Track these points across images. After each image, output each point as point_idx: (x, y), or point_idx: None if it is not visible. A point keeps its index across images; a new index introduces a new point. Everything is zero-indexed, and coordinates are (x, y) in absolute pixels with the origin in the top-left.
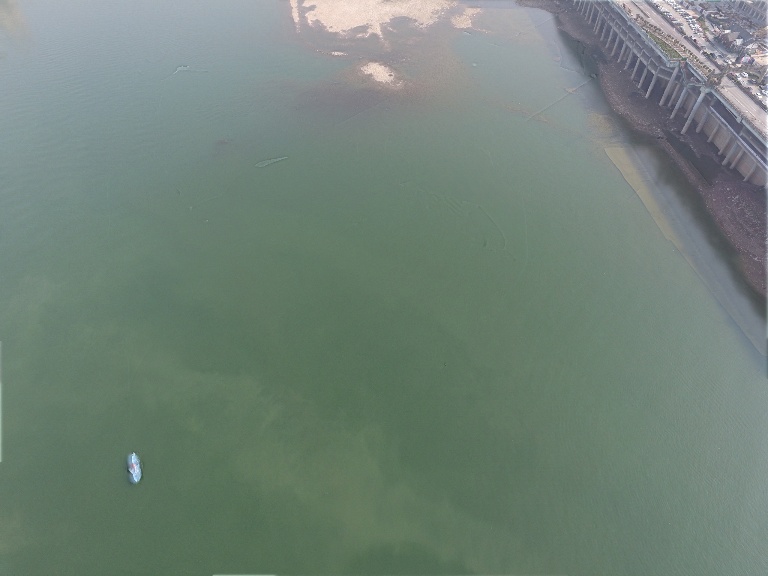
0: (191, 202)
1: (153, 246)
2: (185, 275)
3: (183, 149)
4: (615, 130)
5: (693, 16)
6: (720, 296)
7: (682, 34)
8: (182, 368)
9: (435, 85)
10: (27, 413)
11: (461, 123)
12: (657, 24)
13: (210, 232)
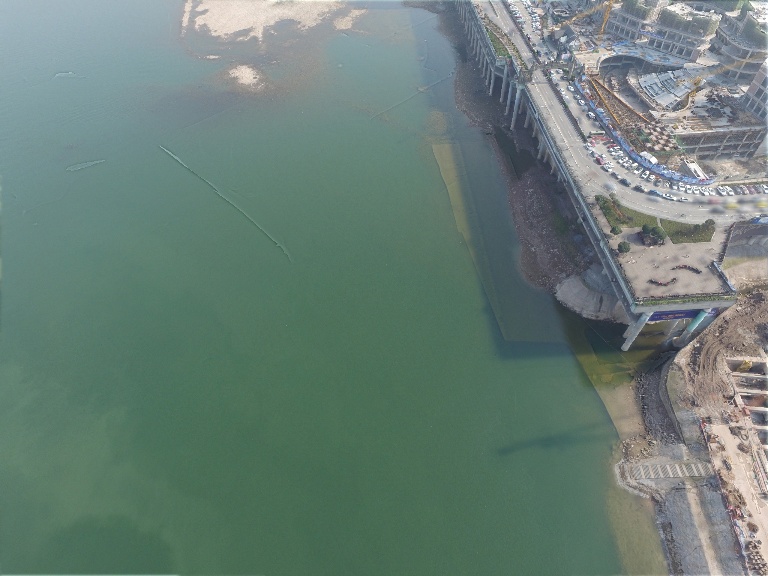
0: (26, 206)
1: None
2: None
3: (27, 154)
4: (449, 127)
5: (539, 14)
6: (487, 285)
7: (520, 32)
8: None
9: (294, 86)
10: None
11: (306, 123)
12: (502, 23)
13: (33, 235)
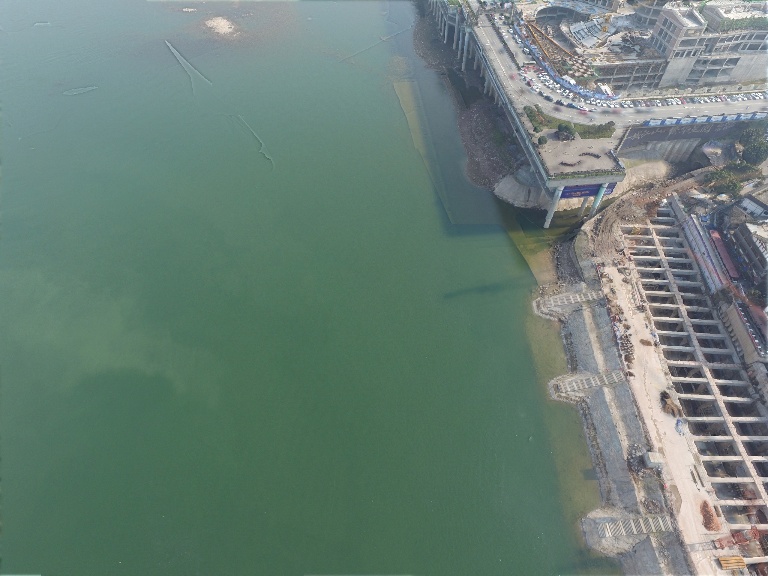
0: (21, 134)
1: None
2: None
3: (18, 89)
4: (409, 69)
5: None
6: (438, 186)
7: None
8: None
9: (267, 35)
10: None
11: (280, 66)
12: None
13: (32, 156)
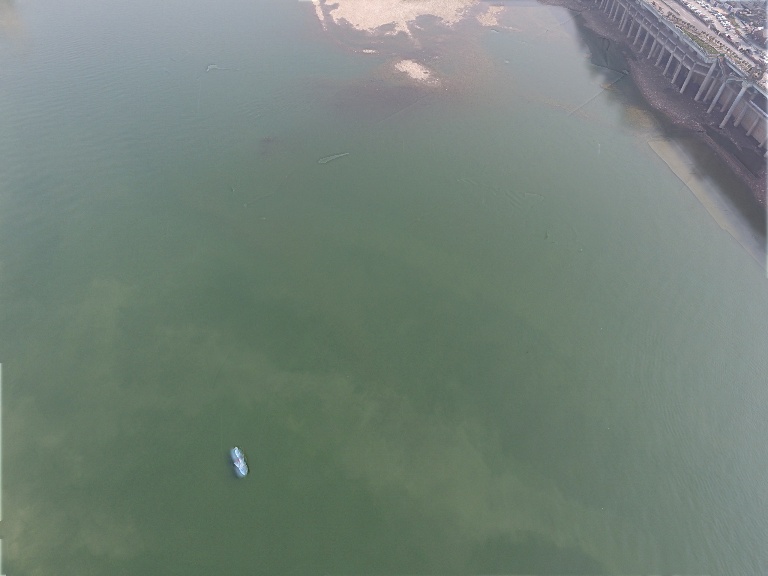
0: (245, 200)
1: (218, 243)
2: (256, 272)
3: (231, 147)
4: (655, 125)
5: (722, 13)
6: None
7: (715, 31)
8: (273, 363)
9: (472, 82)
10: (112, 412)
11: (504, 119)
12: (689, 21)
13: (270, 229)
